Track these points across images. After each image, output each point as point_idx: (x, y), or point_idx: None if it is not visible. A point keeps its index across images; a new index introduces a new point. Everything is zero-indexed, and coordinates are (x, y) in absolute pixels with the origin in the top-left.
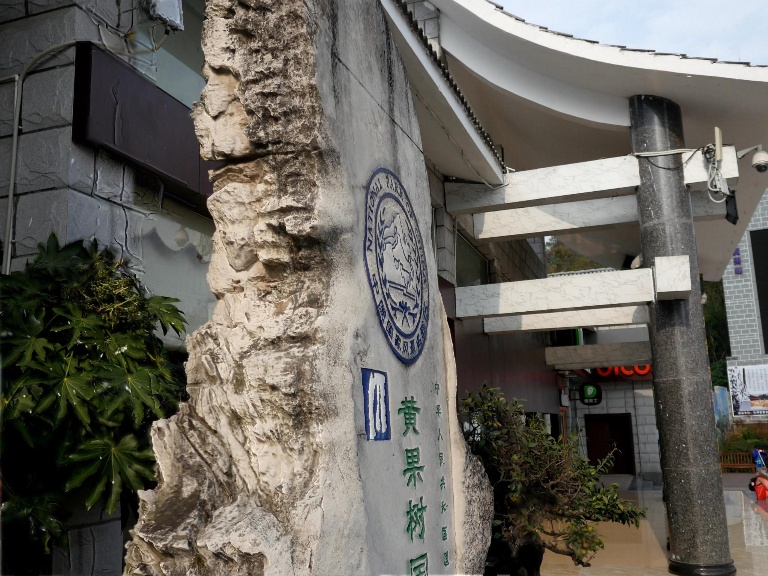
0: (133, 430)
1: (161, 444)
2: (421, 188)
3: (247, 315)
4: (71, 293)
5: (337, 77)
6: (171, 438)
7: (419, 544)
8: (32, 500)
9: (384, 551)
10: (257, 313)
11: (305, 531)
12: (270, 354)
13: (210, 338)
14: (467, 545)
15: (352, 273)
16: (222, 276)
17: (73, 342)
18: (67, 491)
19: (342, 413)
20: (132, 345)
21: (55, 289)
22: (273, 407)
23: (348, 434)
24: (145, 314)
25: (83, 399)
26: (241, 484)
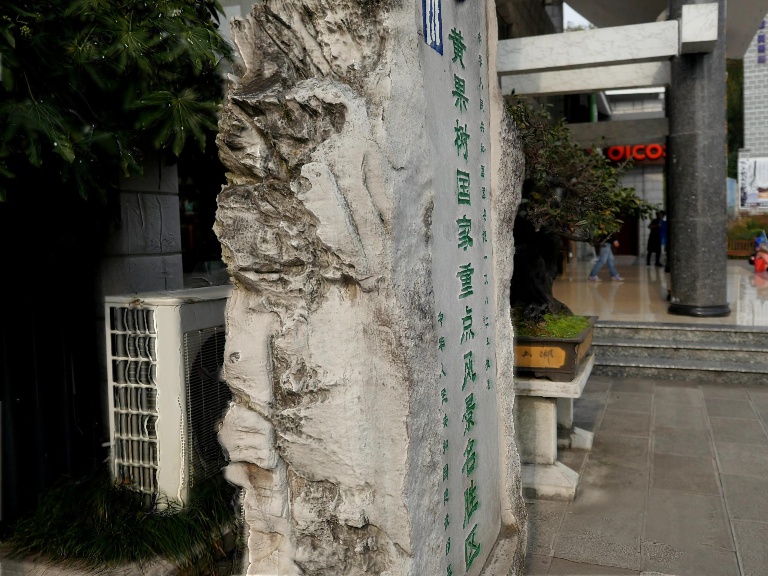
0: (196, 82)
1: (242, 36)
2: None
3: None
4: None
5: None
6: (251, 30)
7: (463, 162)
8: (116, 130)
9: (437, 145)
10: None
11: (377, 93)
12: None
13: None
14: (501, 190)
15: None
16: None
17: (132, 1)
18: (144, 129)
19: (405, 6)
20: (187, 7)
21: None
22: None
23: (410, 26)
24: None
25: (148, 51)
26: (315, 71)
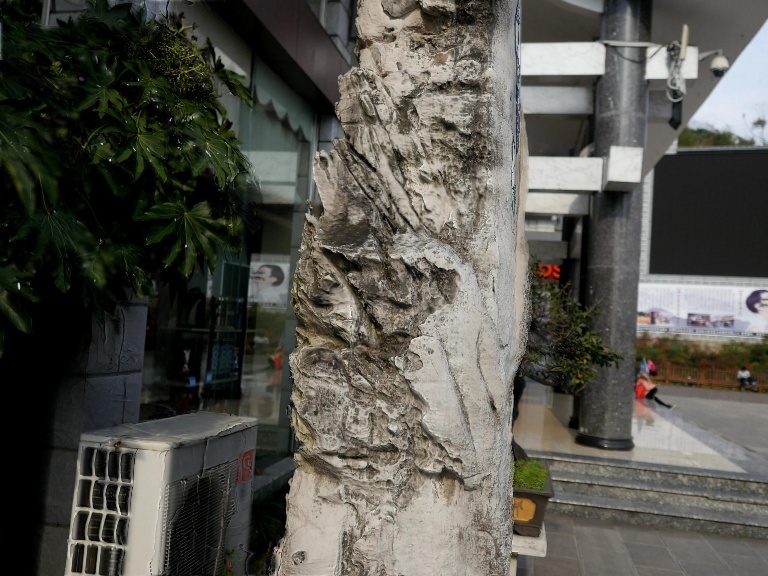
0: (207, 197)
1: (323, 174)
2: None
3: (398, 65)
4: (137, 50)
5: None
6: (334, 169)
7: None
8: (120, 245)
9: None
10: (410, 64)
11: (486, 260)
12: (444, 96)
13: (366, 80)
14: None
15: (507, 37)
16: (372, 23)
17: (142, 100)
18: (147, 245)
19: (505, 165)
20: (201, 114)
21: (116, 45)
22: (444, 148)
23: (508, 186)
24: (208, 87)
25: (158, 158)
26: (402, 221)
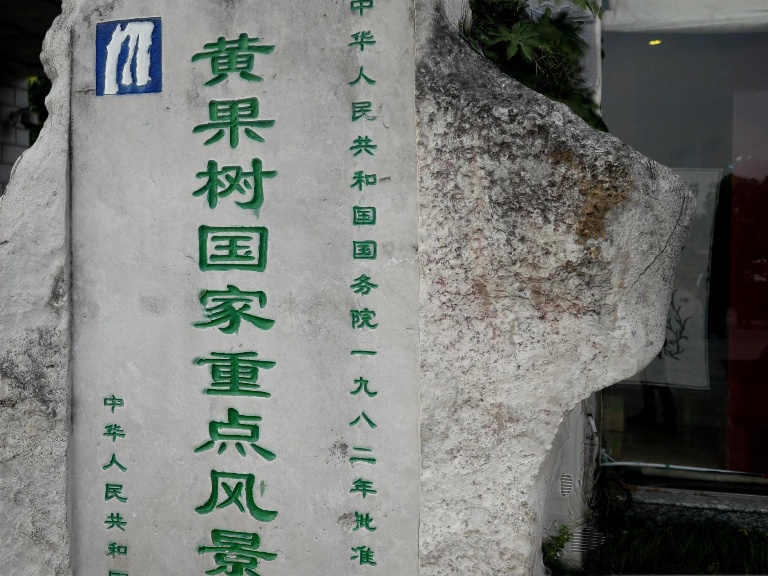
0: None
1: None
2: None
3: None
4: None
5: None
6: None
7: (237, 213)
8: None
9: (125, 205)
10: None
11: None
12: None
13: None
14: (438, 242)
15: None
16: None
17: None
18: None
19: (60, 73)
20: None
21: None
22: None
23: (62, 92)
24: None
25: None
26: None
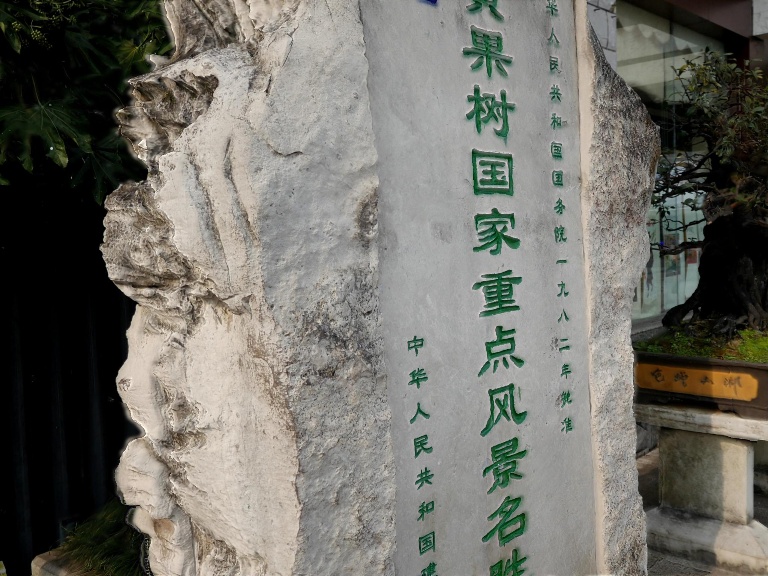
0: None
1: (171, 9)
2: None
3: None
4: None
5: None
6: (179, 1)
7: (494, 140)
8: None
9: (414, 120)
10: None
11: (268, 58)
12: None
13: None
14: (597, 173)
15: None
16: None
17: None
18: None
19: None
20: None
21: None
22: None
23: None
24: None
25: None
26: (241, 40)
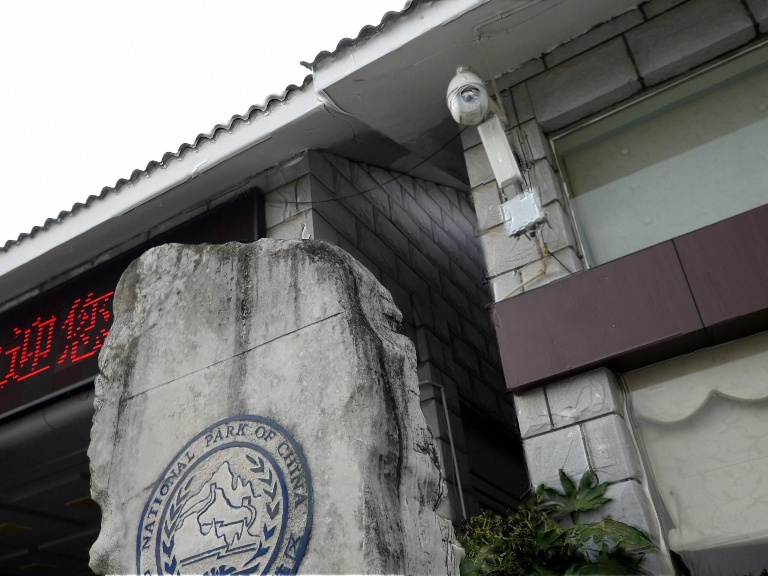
0: None
1: None
2: (318, 371)
3: None
4: None
5: (124, 417)
6: None
7: None
8: None
9: None
10: None
11: None
12: None
13: None
14: None
15: None
16: None
17: None
18: None
19: None
20: None
21: None
22: None
23: None
24: None
25: None
26: None
